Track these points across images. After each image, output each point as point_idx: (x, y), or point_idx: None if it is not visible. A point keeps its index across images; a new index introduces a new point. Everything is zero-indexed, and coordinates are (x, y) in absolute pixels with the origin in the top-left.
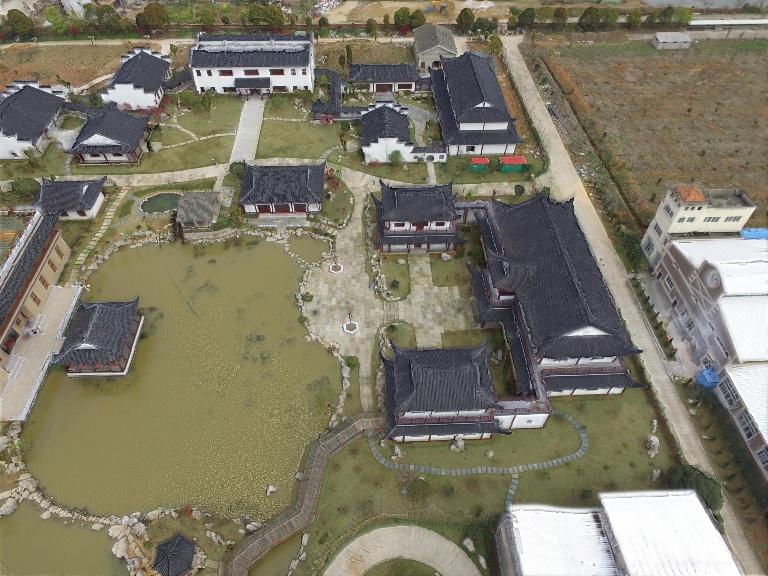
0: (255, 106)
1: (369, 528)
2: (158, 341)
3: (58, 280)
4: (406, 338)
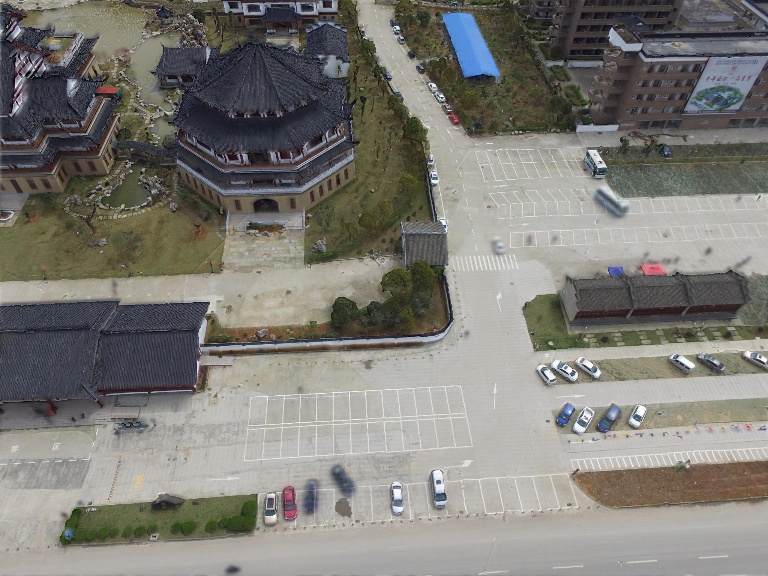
0: None
1: None
2: None
3: None
4: None
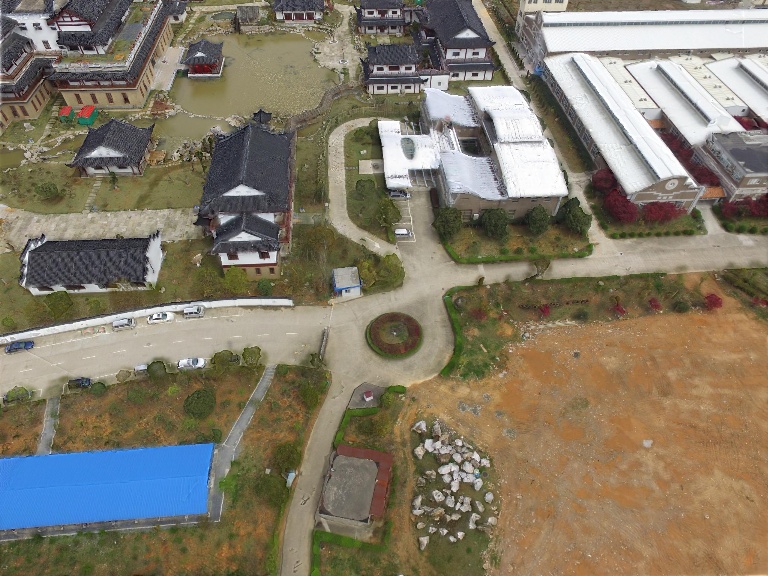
0: None
1: (356, 118)
2: (234, 69)
3: (170, 45)
4: None
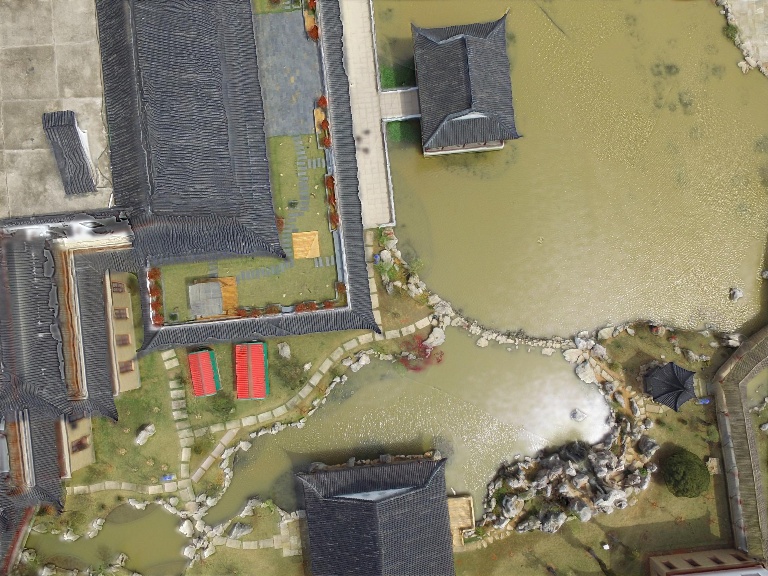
0: None
1: None
2: (517, 85)
3: None
4: None
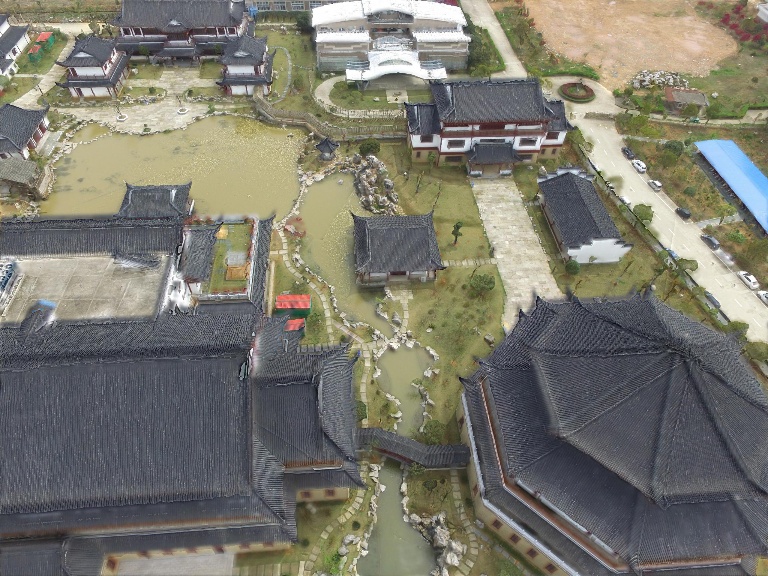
0: None
1: None
2: None
3: None
4: (200, 90)
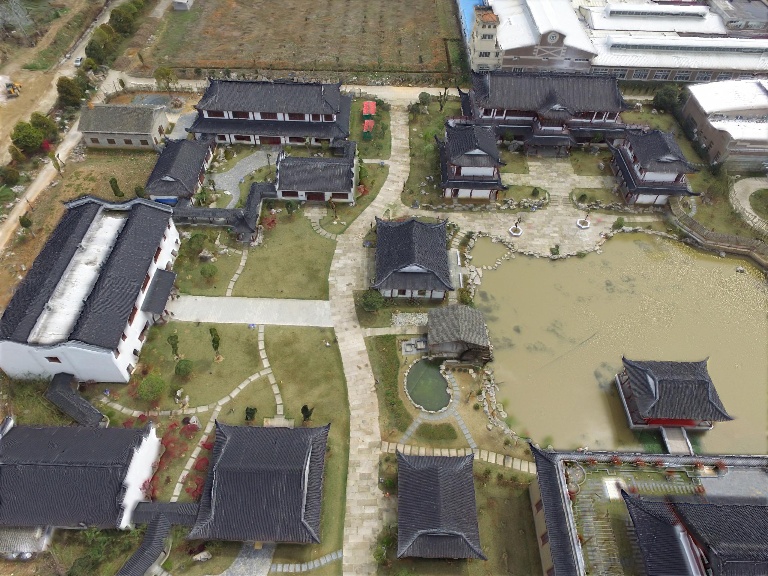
0: (189, 307)
1: None
2: None
3: None
4: (588, 193)
